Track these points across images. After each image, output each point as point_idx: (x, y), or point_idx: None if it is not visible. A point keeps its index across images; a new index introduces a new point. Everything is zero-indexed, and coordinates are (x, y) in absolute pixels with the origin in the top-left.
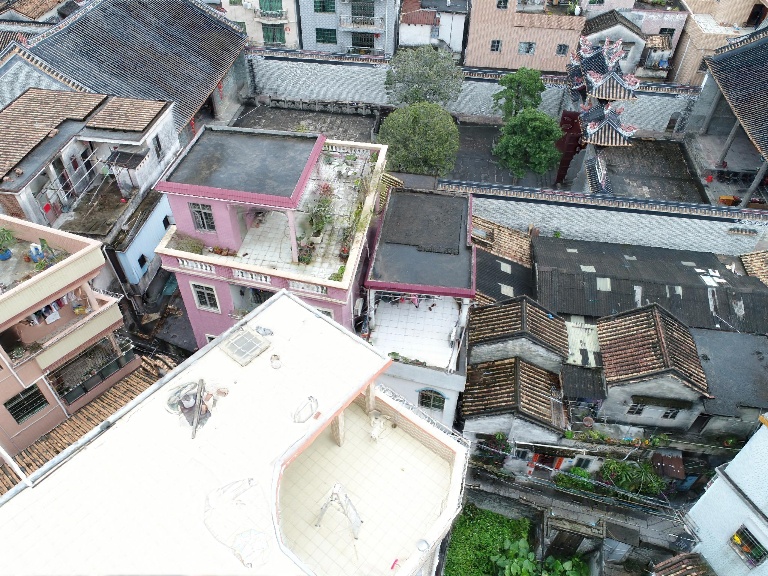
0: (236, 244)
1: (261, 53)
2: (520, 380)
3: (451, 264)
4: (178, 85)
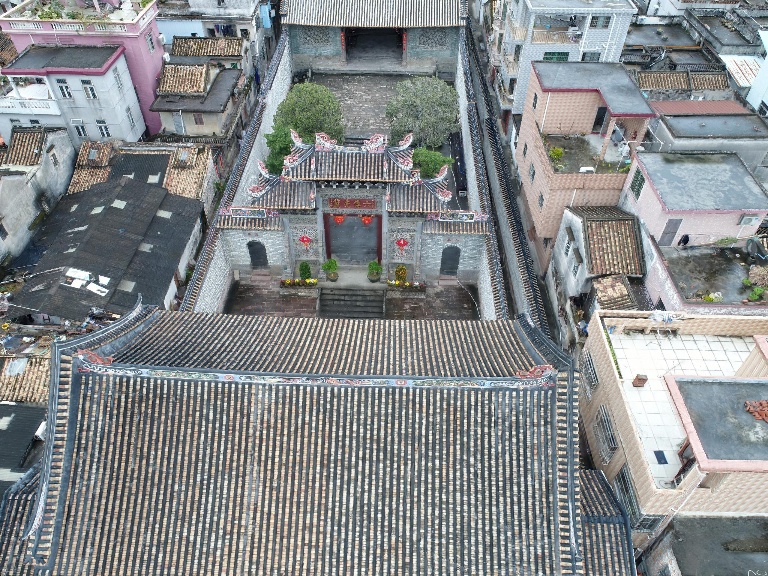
0: (59, 1)
1: (460, 41)
2: (6, 152)
3: (34, 66)
4: (349, 7)
